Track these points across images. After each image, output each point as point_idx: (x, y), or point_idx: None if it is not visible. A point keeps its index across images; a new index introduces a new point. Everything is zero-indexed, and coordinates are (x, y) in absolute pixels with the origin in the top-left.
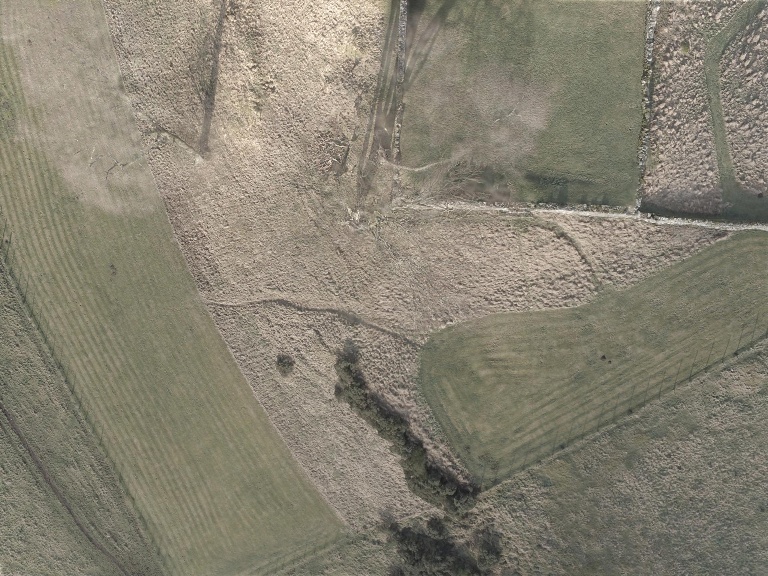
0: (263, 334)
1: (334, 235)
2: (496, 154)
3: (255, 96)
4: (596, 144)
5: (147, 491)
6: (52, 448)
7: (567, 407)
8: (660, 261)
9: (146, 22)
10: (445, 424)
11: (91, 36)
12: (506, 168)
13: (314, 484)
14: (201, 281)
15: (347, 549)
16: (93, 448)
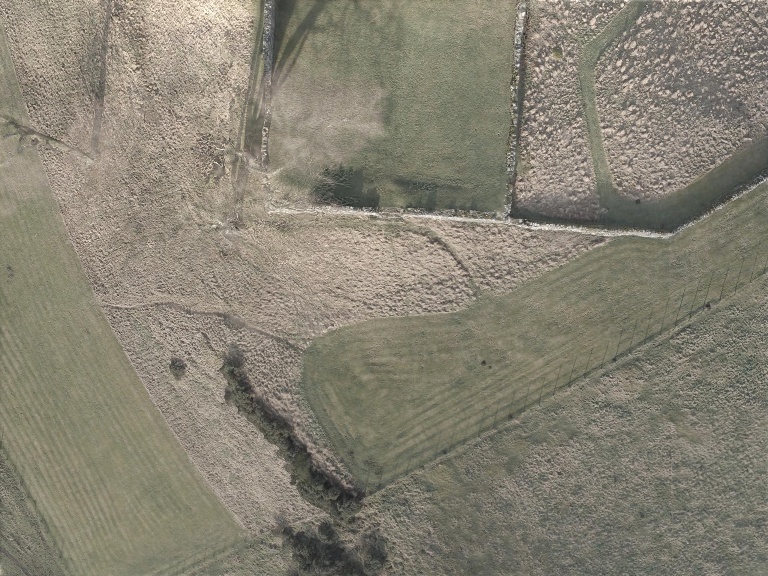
0: (157, 337)
1: (217, 238)
2: (366, 158)
3: (139, 98)
4: (465, 149)
5: (48, 494)
6: None
7: (449, 412)
8: (537, 267)
9: (39, 22)
10: (328, 428)
11: None
12: (376, 173)
13: (212, 488)
14: (96, 283)
15: (245, 553)
16: None
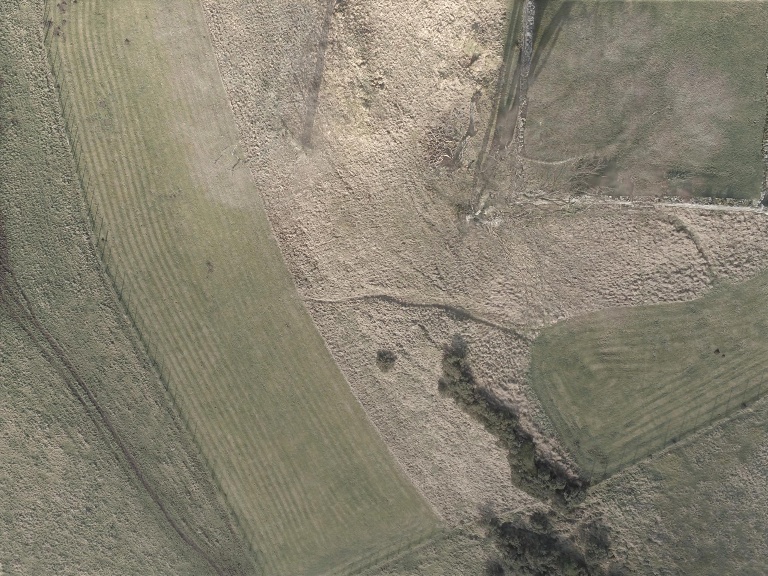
0: (363, 330)
1: (444, 230)
2: (619, 148)
3: (364, 93)
4: (720, 137)
5: (240, 487)
6: (145, 445)
7: (679, 401)
8: None
9: (246, 20)
10: (555, 418)
11: (189, 35)
12: (629, 162)
13: (410, 479)
14: (299, 278)
15: (443, 544)
16: (186, 444)
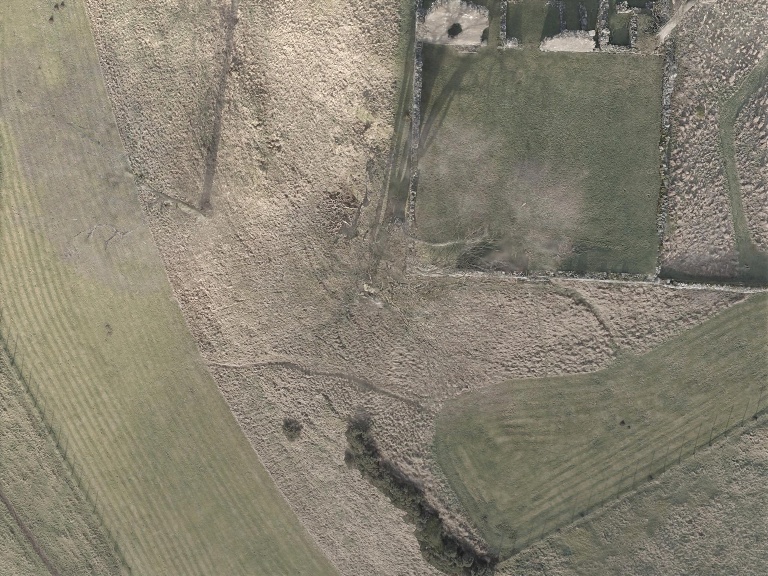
0: (268, 397)
1: (344, 299)
2: (513, 221)
3: (260, 155)
4: (615, 210)
5: (144, 560)
6: (42, 517)
7: (586, 474)
8: (678, 325)
9: (144, 74)
10: (461, 493)
11: (85, 87)
12: (524, 235)
13: (322, 551)
14: (202, 341)
15: None
16: (86, 516)
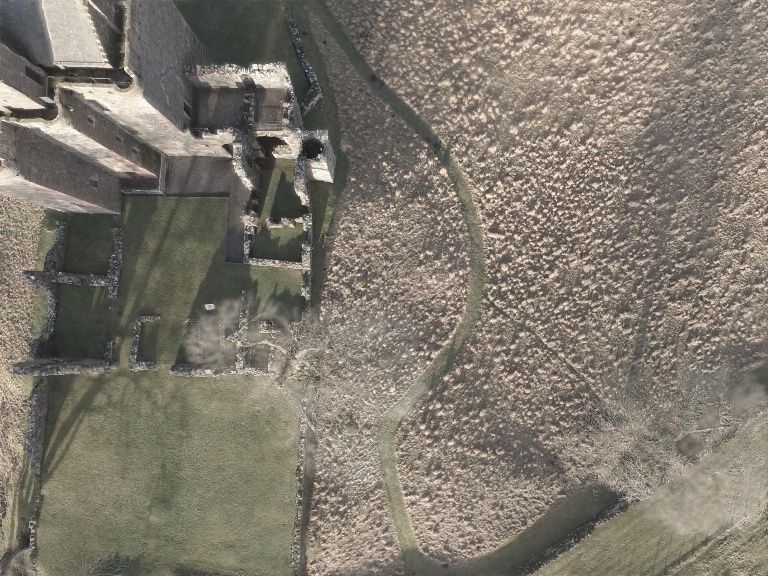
0: None
1: None
2: (144, 546)
3: None
4: (249, 538)
5: None
6: None
7: None
8: None
9: None
10: None
11: None
12: (154, 561)
13: None
14: None
15: None
16: None
